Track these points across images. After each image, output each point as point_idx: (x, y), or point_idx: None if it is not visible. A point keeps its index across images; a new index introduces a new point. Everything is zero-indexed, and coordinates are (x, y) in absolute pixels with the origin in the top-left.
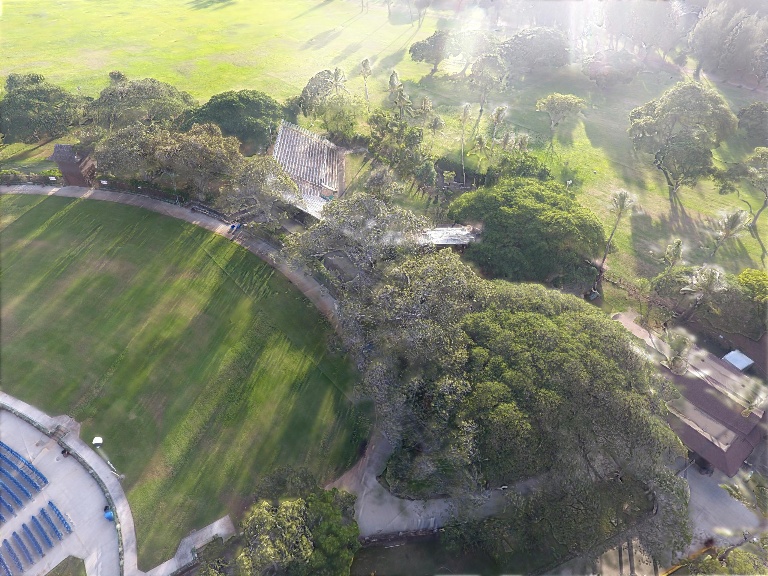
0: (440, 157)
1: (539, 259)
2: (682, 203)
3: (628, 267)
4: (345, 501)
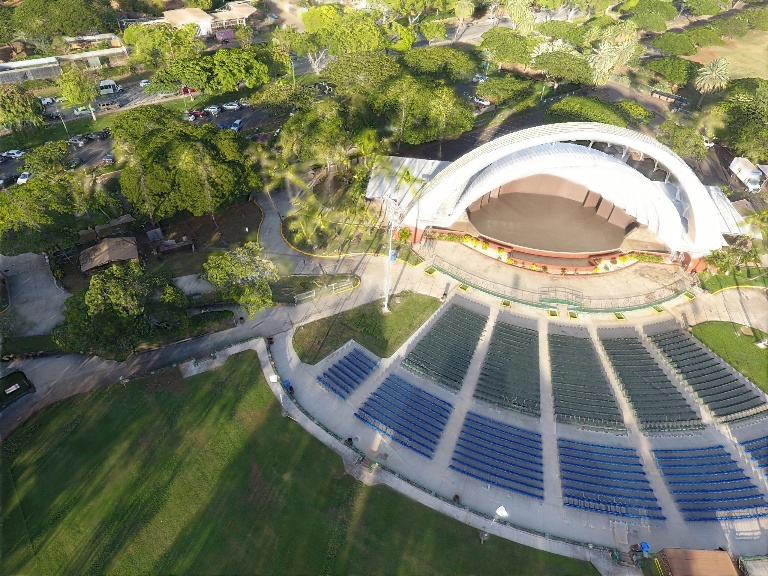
0: None
1: None
2: None
3: None
4: (61, 329)
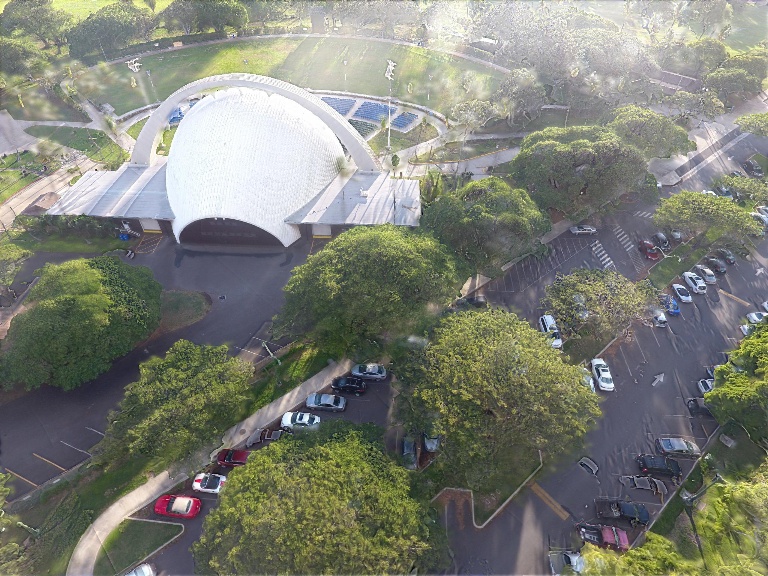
0: None
1: None
2: (658, 40)
3: None
4: None
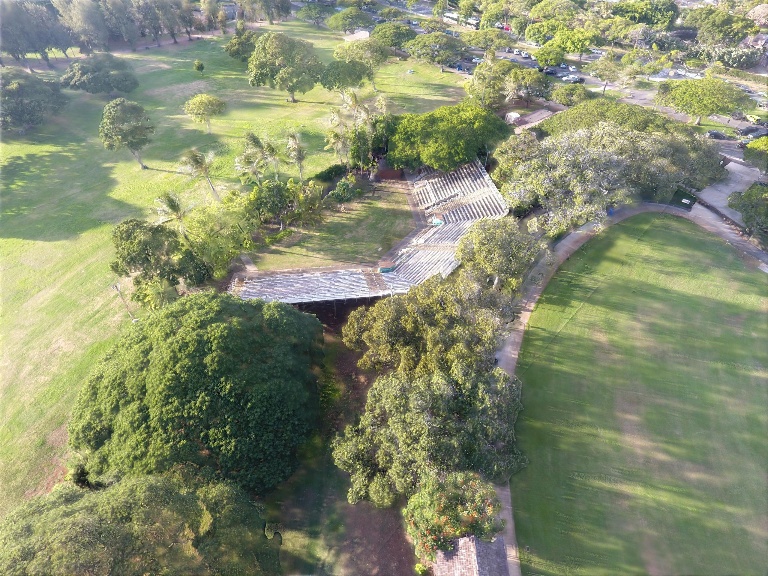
0: None
1: (508, 131)
2: None
3: None
4: (739, 194)
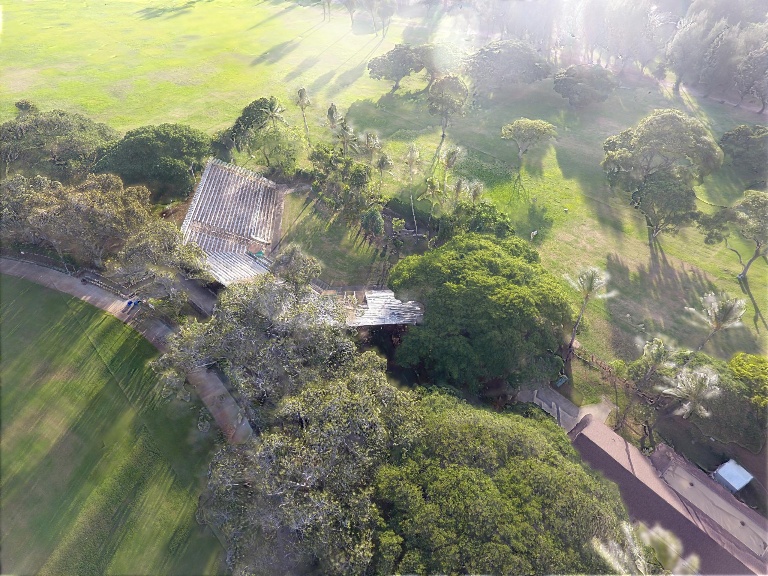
0: (391, 197)
1: (491, 352)
2: (663, 249)
3: (602, 338)
4: None
